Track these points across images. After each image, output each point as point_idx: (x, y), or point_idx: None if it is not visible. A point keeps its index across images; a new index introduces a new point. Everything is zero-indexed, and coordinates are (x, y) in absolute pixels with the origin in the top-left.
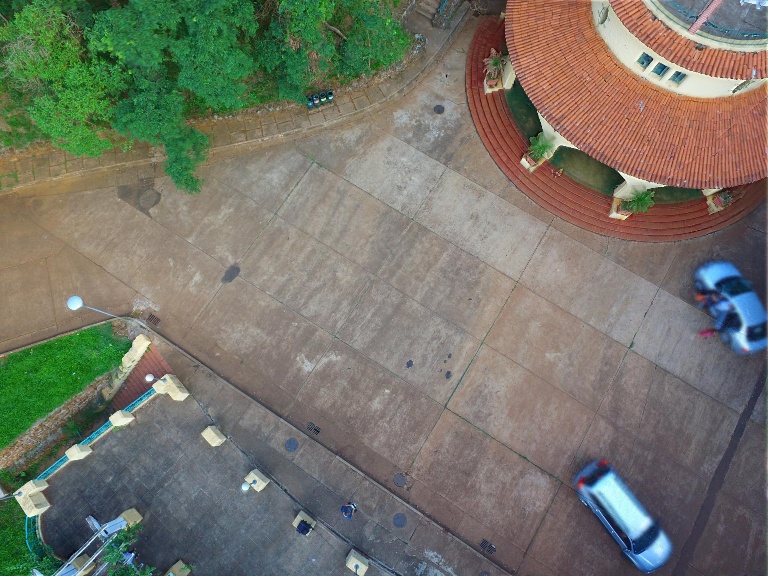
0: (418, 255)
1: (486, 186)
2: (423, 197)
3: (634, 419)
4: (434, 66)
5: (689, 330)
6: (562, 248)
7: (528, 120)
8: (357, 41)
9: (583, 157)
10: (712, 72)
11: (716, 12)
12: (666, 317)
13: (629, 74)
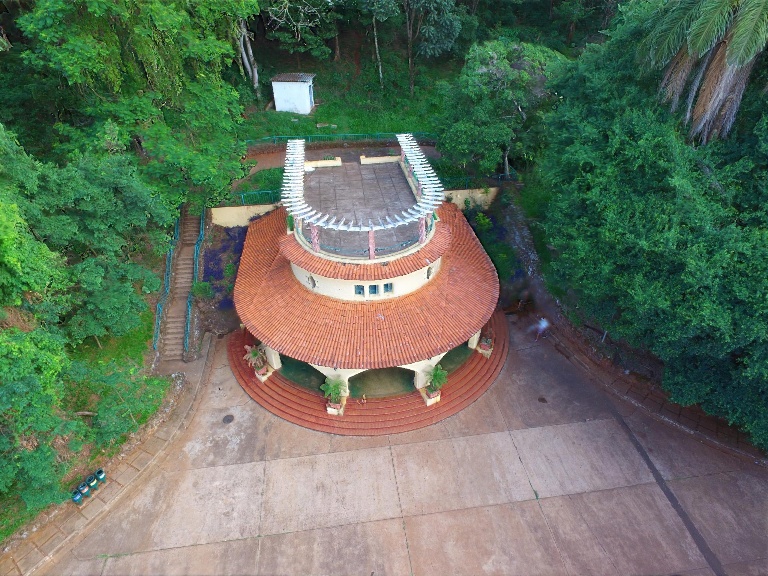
0: (287, 570)
1: (312, 452)
2: (257, 505)
3: (604, 563)
4: (204, 390)
5: (558, 446)
6: (414, 457)
7: (311, 379)
8: (108, 405)
9: (373, 378)
10: (404, 272)
11: (378, 245)
12: (535, 450)
13: (357, 304)
